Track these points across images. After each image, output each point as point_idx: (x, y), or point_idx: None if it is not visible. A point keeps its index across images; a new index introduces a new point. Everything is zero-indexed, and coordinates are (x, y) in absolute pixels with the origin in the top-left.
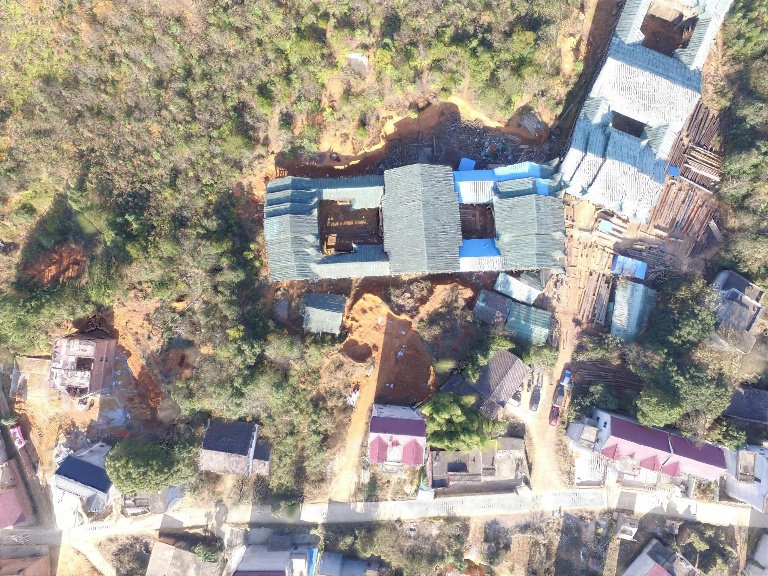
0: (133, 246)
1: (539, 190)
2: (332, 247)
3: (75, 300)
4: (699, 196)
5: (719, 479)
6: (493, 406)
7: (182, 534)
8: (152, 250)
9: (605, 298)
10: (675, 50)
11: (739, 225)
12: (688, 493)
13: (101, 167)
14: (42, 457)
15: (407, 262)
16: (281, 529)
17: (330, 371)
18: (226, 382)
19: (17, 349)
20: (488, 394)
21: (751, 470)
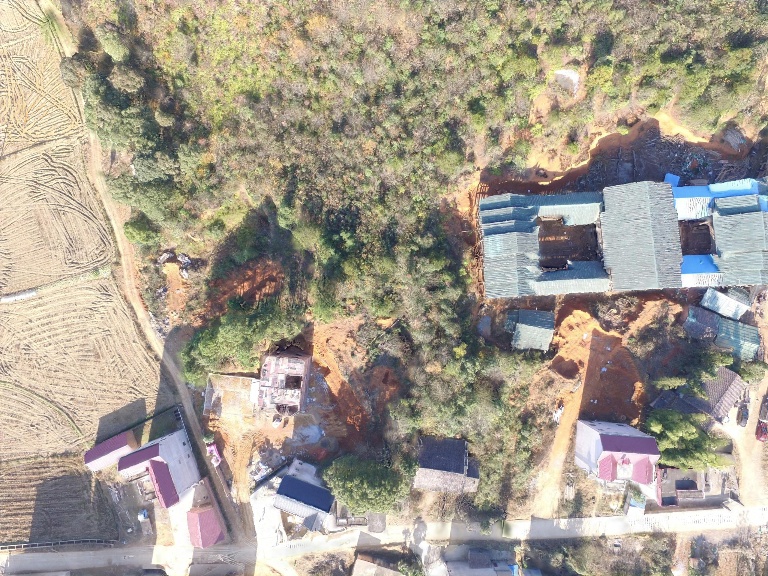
0: (351, 264)
1: (762, 207)
2: None
3: (279, 317)
4: None
5: None
6: (709, 422)
7: (379, 551)
8: (366, 268)
9: None
10: None
11: None
12: None
13: (308, 184)
14: (236, 475)
15: (633, 279)
16: (483, 546)
17: (540, 388)
18: (451, 401)
19: (211, 366)
20: (708, 411)
21: None
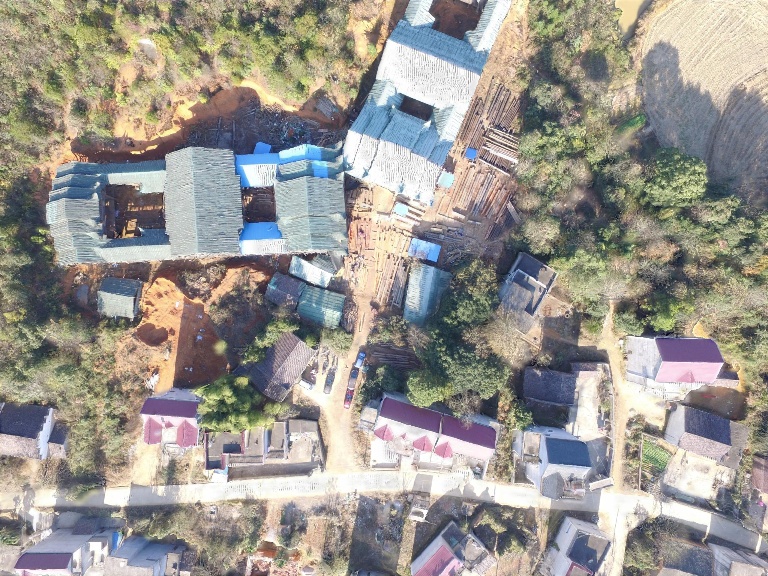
0: None
1: (316, 172)
2: (132, 232)
3: None
4: (499, 178)
5: (515, 461)
6: (279, 388)
7: None
8: None
9: (402, 281)
10: (465, 32)
11: (530, 207)
12: (482, 475)
13: None
14: None
15: (182, 245)
16: (85, 513)
17: (124, 355)
18: (6, 365)
19: None
20: (270, 376)
21: (536, 451)
